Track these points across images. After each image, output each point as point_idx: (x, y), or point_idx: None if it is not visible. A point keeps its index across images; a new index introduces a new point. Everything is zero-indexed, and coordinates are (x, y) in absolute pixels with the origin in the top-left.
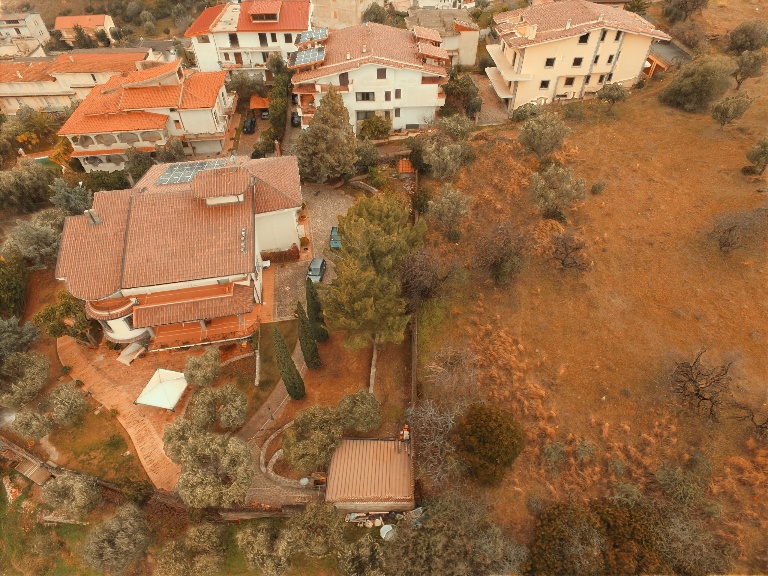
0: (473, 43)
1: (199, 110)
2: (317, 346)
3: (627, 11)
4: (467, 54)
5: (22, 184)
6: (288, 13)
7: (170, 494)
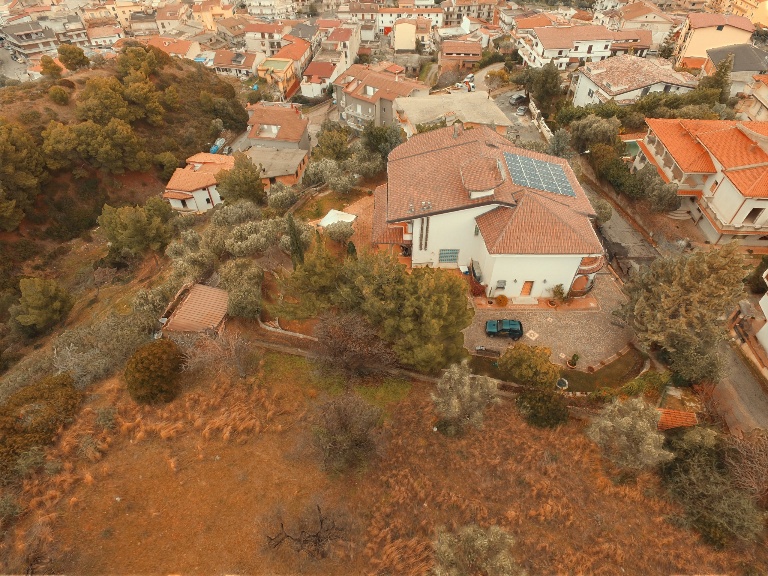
0: None
1: None
2: None
3: None
4: None
5: (586, 129)
6: None
7: None
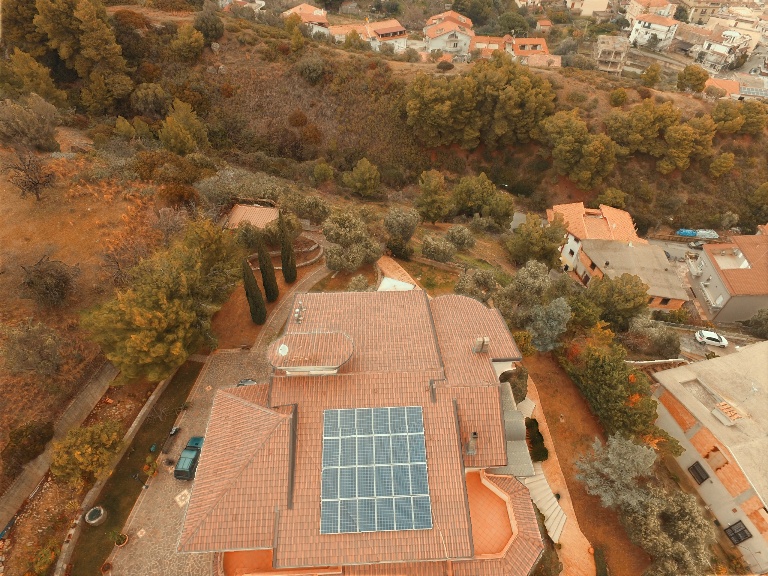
0: None
1: None
2: (267, 318)
3: None
4: None
5: None
6: None
7: (373, 231)
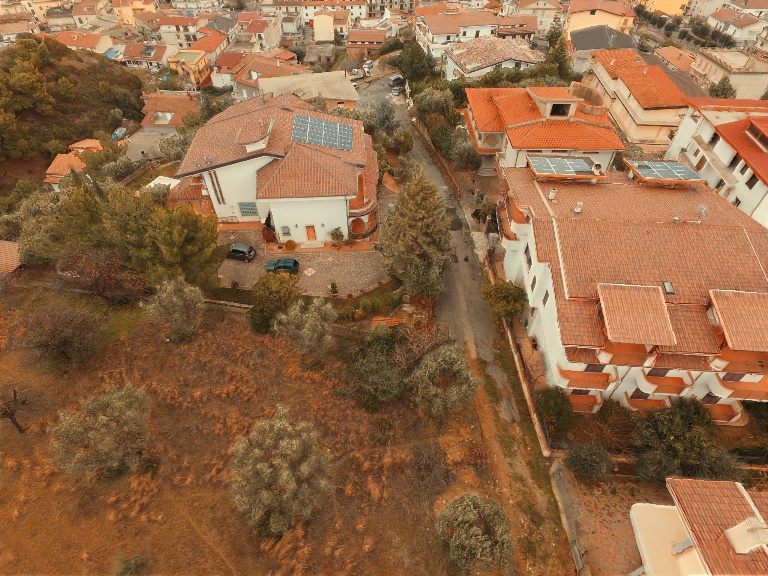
0: None
1: None
2: None
3: None
4: None
5: None
6: None
7: None
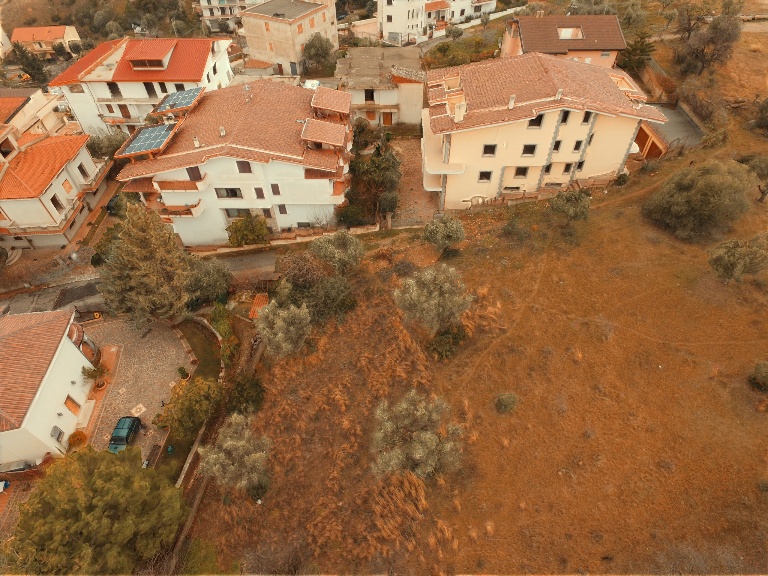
0: (417, 97)
1: (20, 200)
2: None
3: (613, 69)
4: (410, 110)
5: None
6: (181, 57)
7: None
